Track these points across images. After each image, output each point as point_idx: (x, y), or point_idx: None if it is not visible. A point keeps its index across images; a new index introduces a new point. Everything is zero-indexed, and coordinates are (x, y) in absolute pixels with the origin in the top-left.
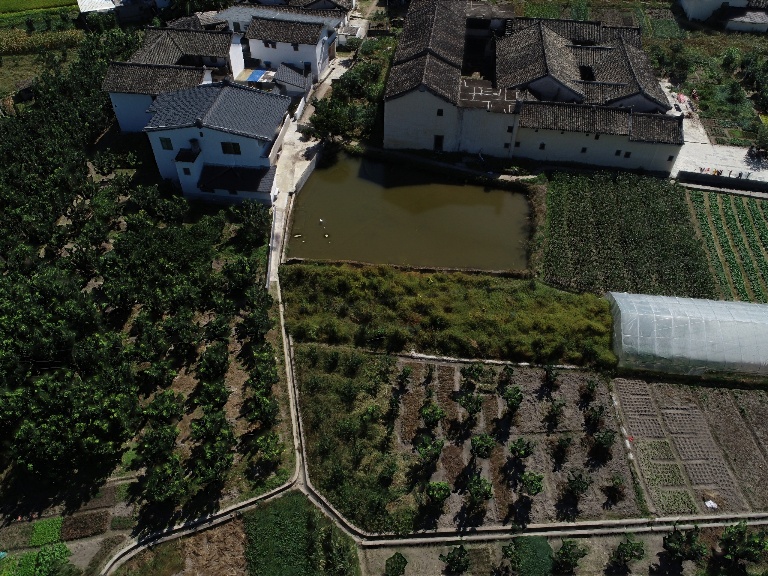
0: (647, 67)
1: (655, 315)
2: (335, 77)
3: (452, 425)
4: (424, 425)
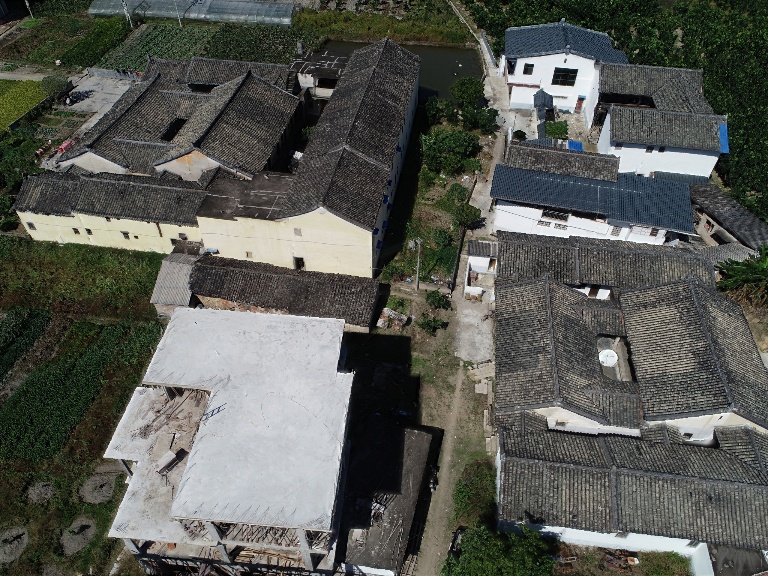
0: (94, 130)
1: (278, 4)
2: (484, 194)
3: (386, 3)
4: (397, 4)
